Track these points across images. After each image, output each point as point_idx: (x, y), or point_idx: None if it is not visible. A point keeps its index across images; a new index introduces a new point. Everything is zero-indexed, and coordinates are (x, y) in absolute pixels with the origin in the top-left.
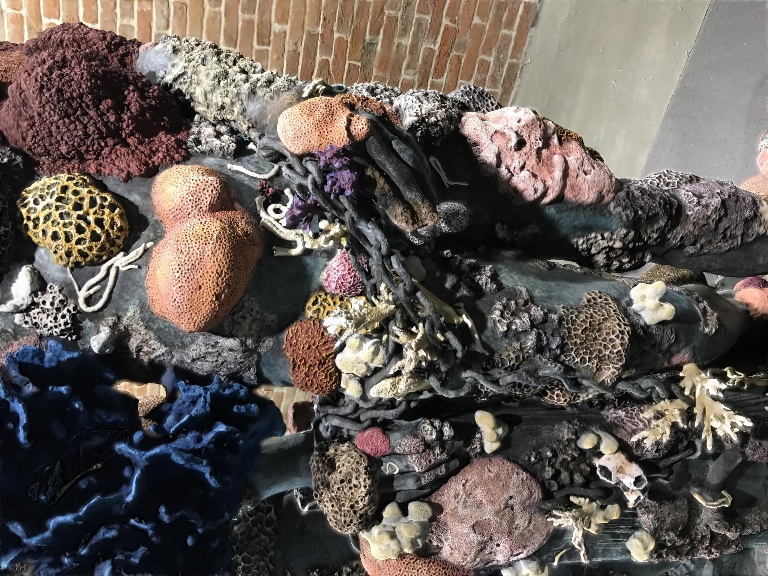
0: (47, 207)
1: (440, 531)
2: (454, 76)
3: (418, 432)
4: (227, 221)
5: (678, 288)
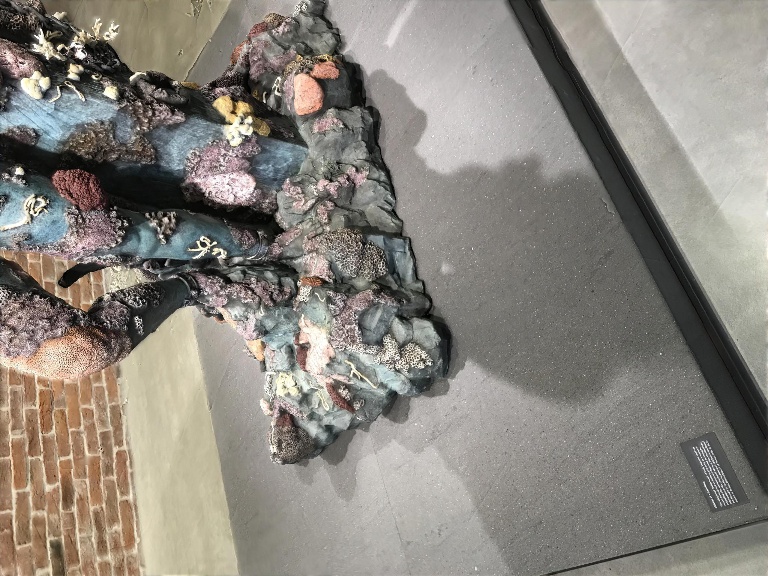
0: None
1: None
2: (63, 428)
3: None
4: None
5: None
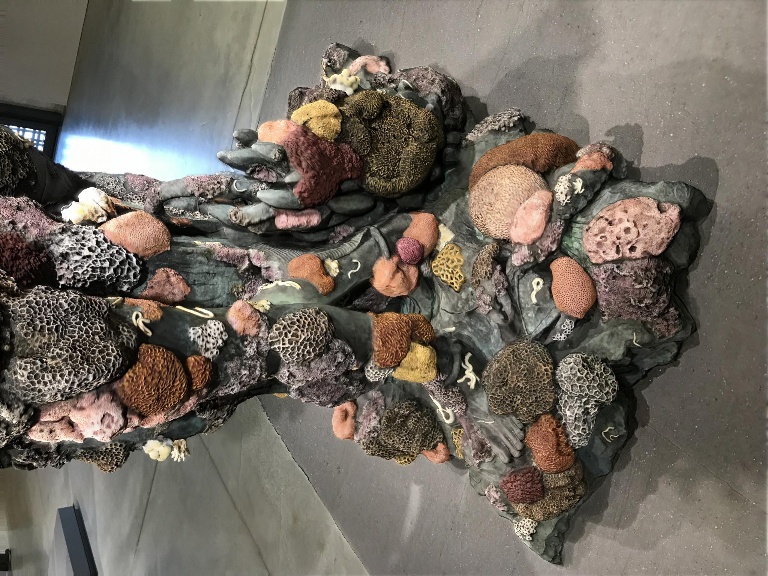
0: None
1: None
2: None
3: None
4: None
5: (208, 415)
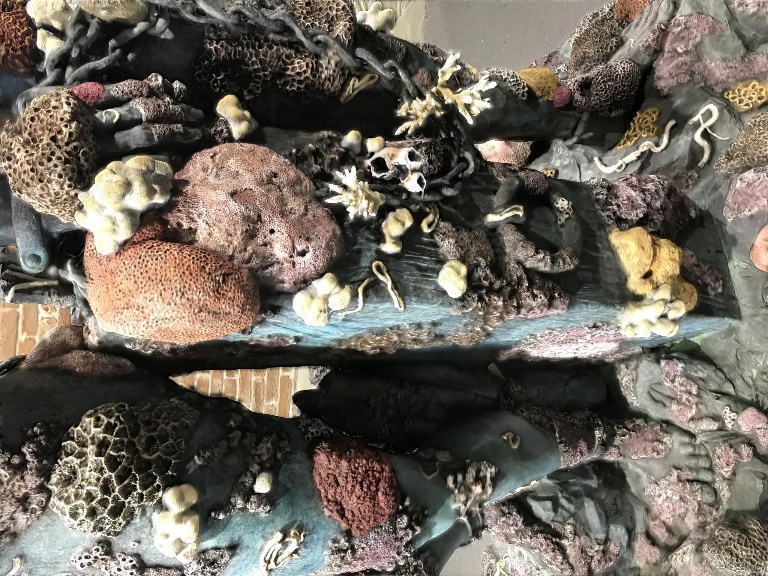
0: None
1: (190, 207)
2: None
3: None
4: None
5: None
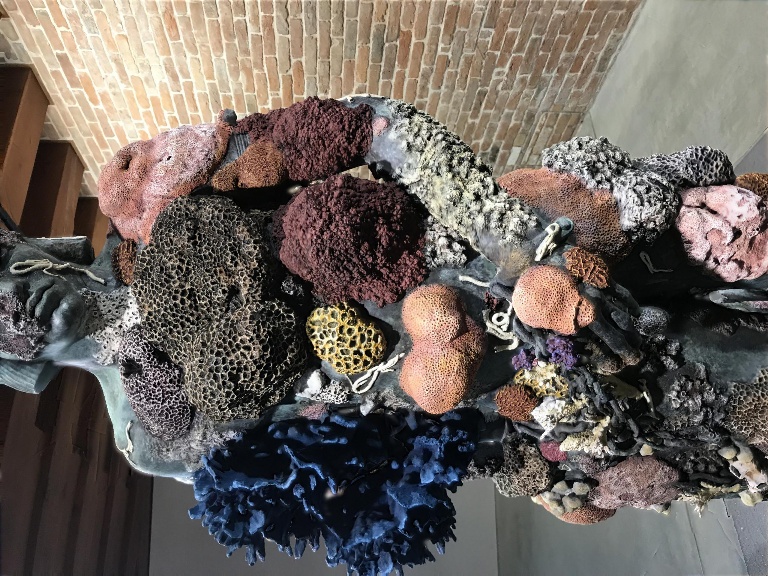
0: (330, 341)
1: (594, 494)
2: None
3: (590, 452)
4: (463, 349)
5: None
